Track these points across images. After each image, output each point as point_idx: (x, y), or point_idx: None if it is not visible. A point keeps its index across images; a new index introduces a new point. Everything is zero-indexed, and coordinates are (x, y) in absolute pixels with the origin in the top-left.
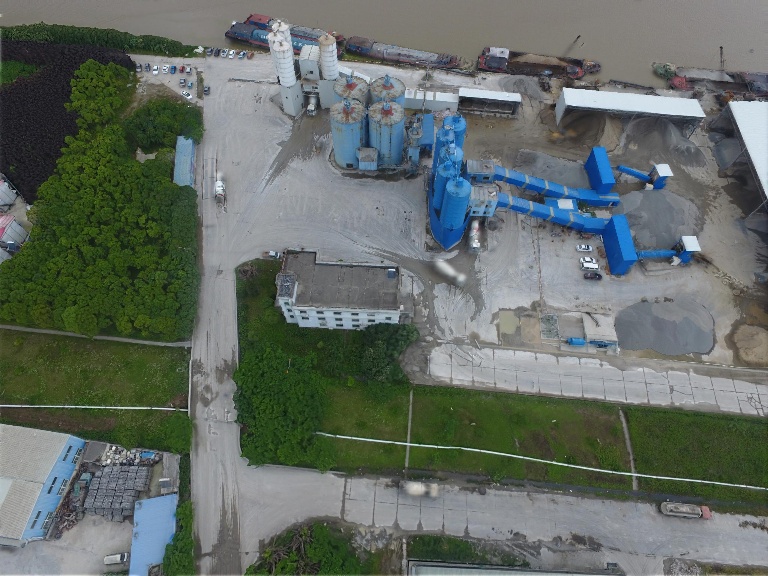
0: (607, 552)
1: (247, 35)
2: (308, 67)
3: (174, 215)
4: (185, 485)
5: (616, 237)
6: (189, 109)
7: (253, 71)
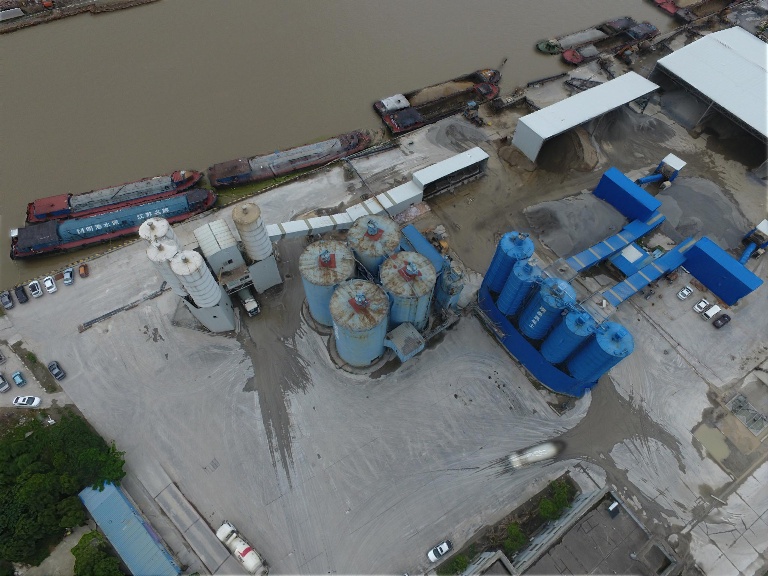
0: None
1: (52, 242)
2: (223, 258)
3: None
4: None
5: (720, 267)
6: (62, 432)
7: (107, 293)
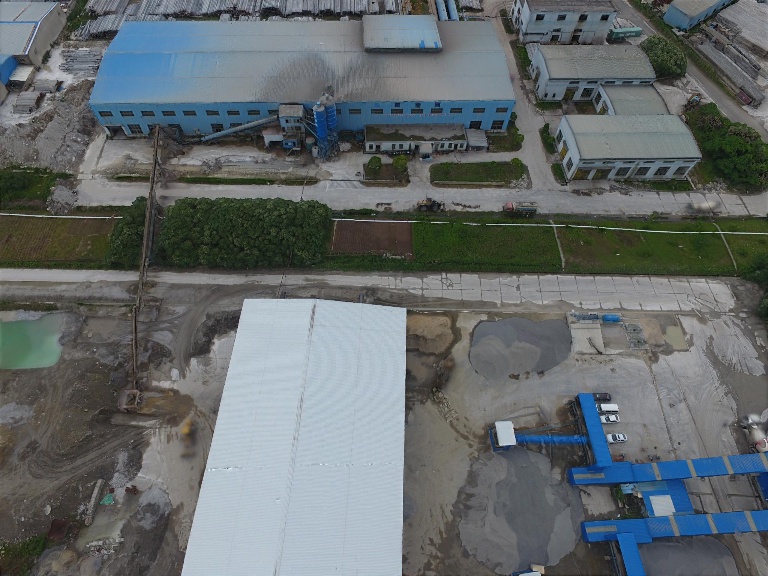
0: (568, 190)
1: None
2: None
3: None
4: None
5: None
6: None
7: None
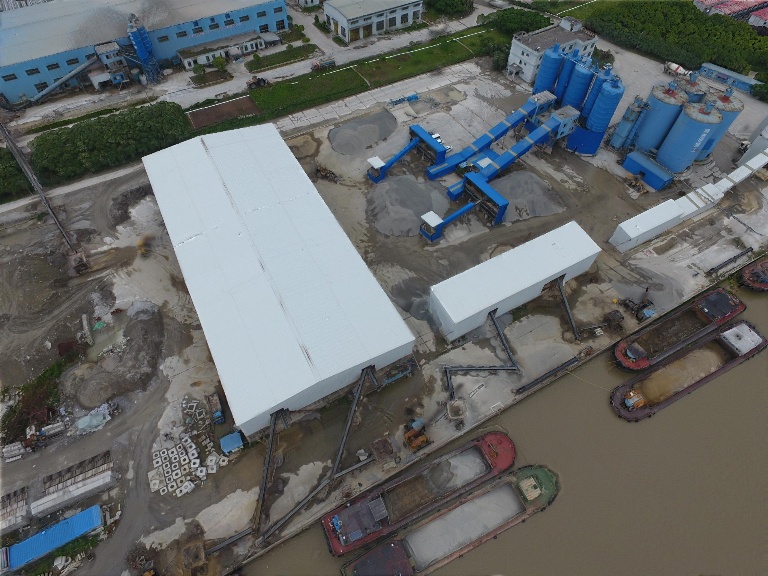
0: (350, 48)
1: None
2: None
3: None
4: (519, 3)
5: None
6: None
7: None
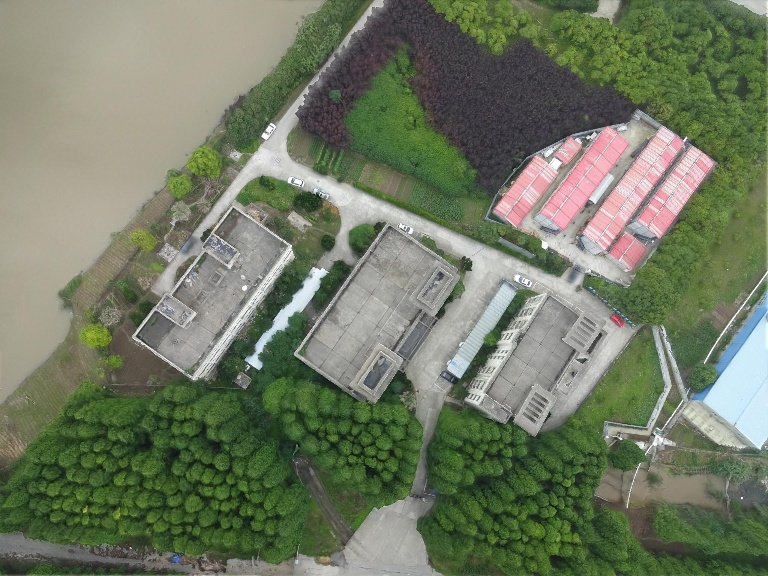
0: None
1: None
2: None
3: (718, 8)
4: None
5: None
6: None
7: None
